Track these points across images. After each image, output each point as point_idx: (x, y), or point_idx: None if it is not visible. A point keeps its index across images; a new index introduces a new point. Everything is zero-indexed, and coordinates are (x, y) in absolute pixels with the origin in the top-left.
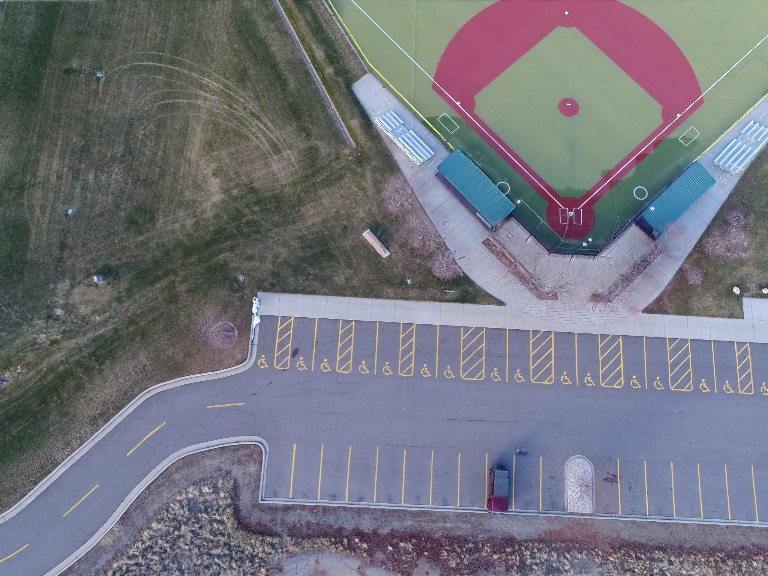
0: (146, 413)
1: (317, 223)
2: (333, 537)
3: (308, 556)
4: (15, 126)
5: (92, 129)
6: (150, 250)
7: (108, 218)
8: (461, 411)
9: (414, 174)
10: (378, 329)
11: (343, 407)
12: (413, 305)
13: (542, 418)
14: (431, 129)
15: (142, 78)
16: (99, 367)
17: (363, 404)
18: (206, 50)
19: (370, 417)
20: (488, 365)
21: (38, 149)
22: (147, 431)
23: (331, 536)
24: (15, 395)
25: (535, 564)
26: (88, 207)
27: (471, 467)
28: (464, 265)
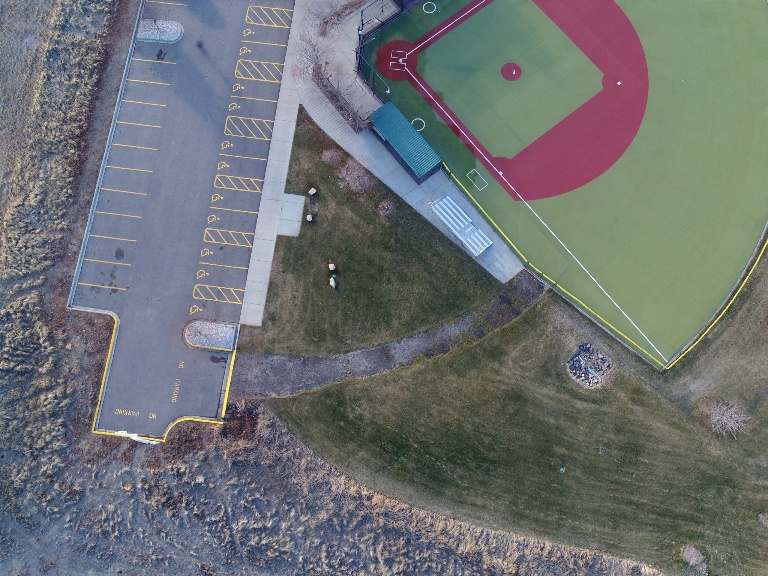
0: None
1: None
2: None
3: None
4: None
5: None
6: None
7: None
8: None
9: None
10: None
11: None
12: None
13: (218, 10)
14: None
15: None
16: None
17: None
18: None
19: None
20: None
21: None
22: None
23: None
24: None
25: None
26: None
27: None
28: None
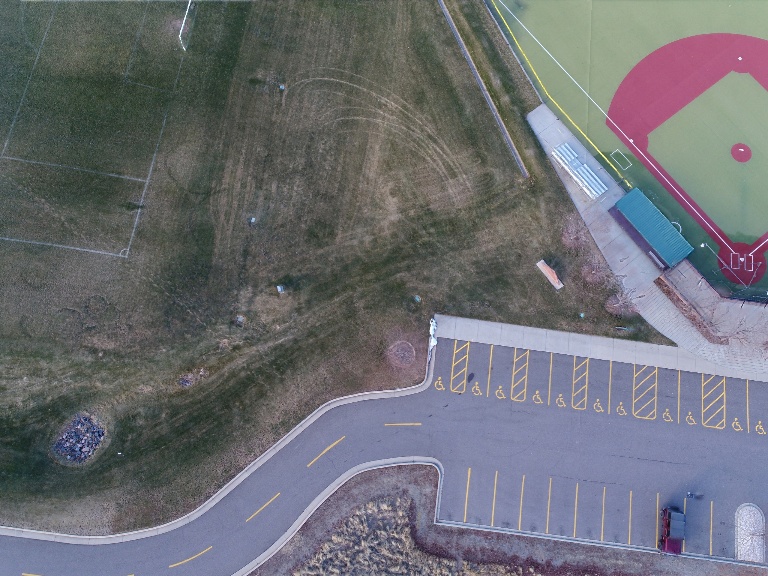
0: (326, 426)
1: (492, 250)
2: (508, 565)
3: None
4: (202, 132)
5: (275, 140)
6: (329, 264)
7: (289, 229)
8: (633, 449)
9: (587, 208)
10: (552, 360)
11: (517, 435)
12: (586, 339)
13: (713, 463)
14: (604, 164)
15: (323, 93)
16: (280, 376)
17: (537, 434)
18: (385, 70)
19: (543, 448)
20: (660, 405)
21: (224, 156)
22: (327, 444)
23: (506, 564)
24: (198, 397)
25: None
26: (271, 217)
27: (642, 506)
28: (635, 303)
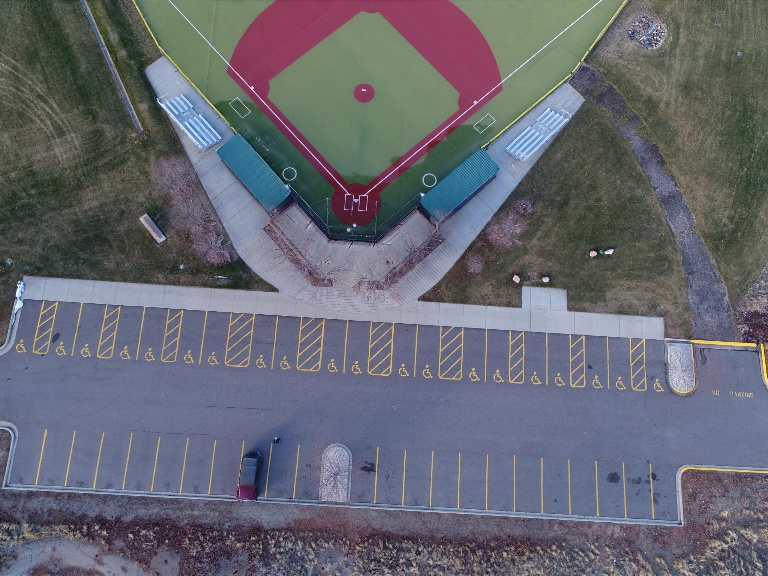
0: None
1: (94, 207)
2: (73, 524)
3: (45, 543)
4: None
5: None
6: None
7: None
8: (221, 398)
9: (200, 159)
10: (144, 314)
11: (100, 393)
12: (183, 291)
13: (304, 406)
14: (222, 113)
15: None
16: None
17: (121, 390)
18: None
19: (126, 403)
20: (254, 352)
21: None
22: None
23: (71, 523)
24: None
25: (279, 553)
26: None
27: (226, 455)
28: (242, 251)
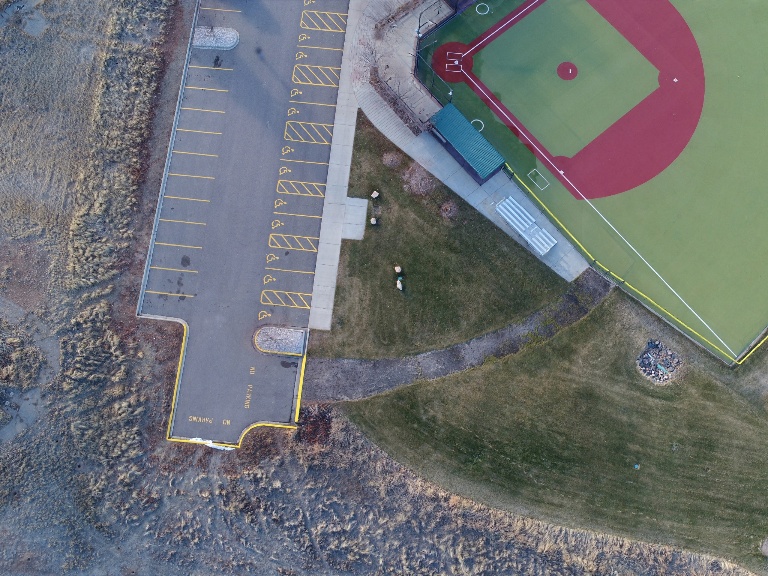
0: None
1: None
2: None
3: None
4: None
5: None
6: None
7: None
8: None
9: None
10: None
11: None
12: None
13: (272, 15)
14: None
15: None
16: None
17: None
18: None
19: None
20: None
21: None
22: None
23: None
24: None
25: None
26: None
27: None
28: None
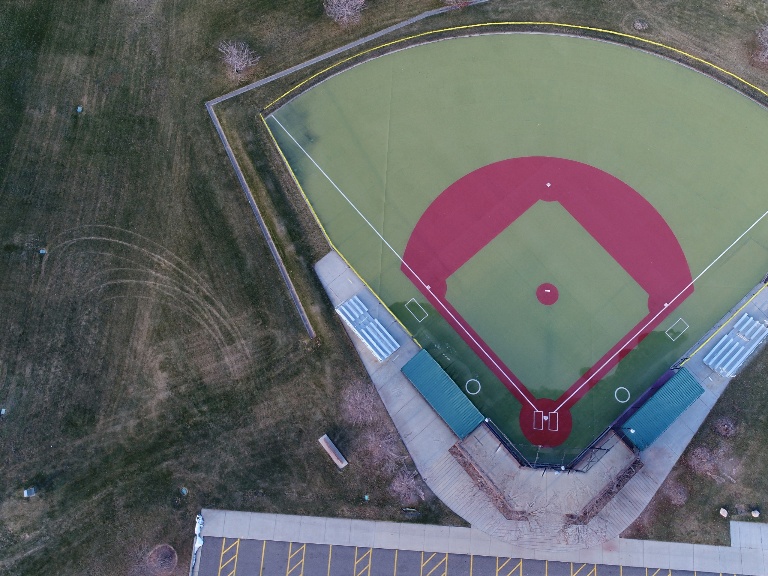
0: None
1: (270, 426)
2: None
3: None
4: None
5: (32, 315)
6: (88, 456)
7: (44, 419)
8: None
9: (377, 369)
10: (331, 554)
11: None
12: (370, 526)
13: None
14: (398, 317)
15: (89, 255)
16: None
17: None
18: (159, 223)
19: None
20: None
21: None
22: None
23: None
24: None
25: None
26: (23, 406)
27: None
28: (428, 477)
